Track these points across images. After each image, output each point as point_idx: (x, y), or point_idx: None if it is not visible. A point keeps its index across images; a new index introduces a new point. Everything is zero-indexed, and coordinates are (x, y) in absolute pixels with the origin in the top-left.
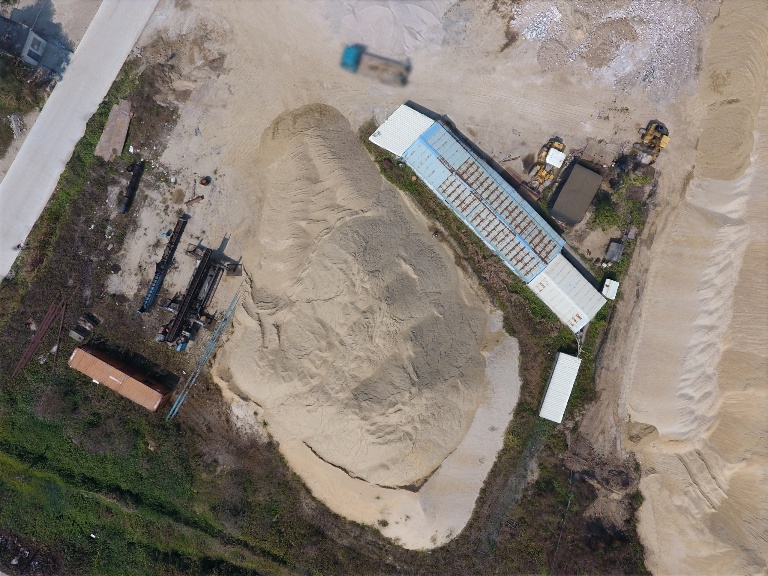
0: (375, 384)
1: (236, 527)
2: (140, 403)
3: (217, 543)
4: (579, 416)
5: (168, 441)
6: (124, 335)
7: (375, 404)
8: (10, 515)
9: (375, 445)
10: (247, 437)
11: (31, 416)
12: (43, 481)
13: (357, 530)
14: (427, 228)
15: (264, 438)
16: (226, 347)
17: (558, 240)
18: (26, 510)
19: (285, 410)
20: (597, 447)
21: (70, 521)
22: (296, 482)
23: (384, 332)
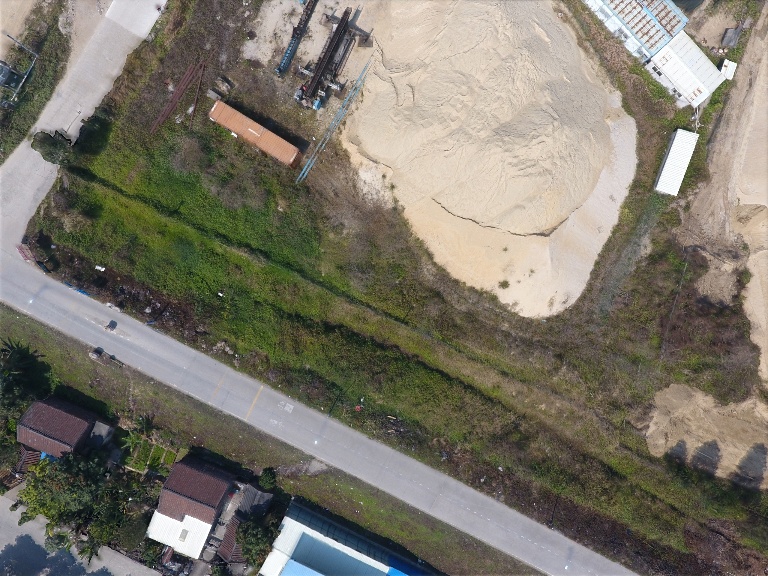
0: (515, 125)
1: (362, 284)
2: (277, 156)
3: (340, 304)
4: (692, 195)
5: (298, 201)
6: (258, 99)
7: (518, 138)
8: (143, 268)
9: (516, 178)
10: (373, 203)
11: (167, 172)
12: (176, 236)
13: (475, 297)
14: (552, 9)
15: (389, 204)
16: (355, 115)
17: (682, 17)
18: (158, 264)
19: (419, 163)
20: (707, 228)
21: (199, 278)
22: (418, 248)
23: (525, 76)
